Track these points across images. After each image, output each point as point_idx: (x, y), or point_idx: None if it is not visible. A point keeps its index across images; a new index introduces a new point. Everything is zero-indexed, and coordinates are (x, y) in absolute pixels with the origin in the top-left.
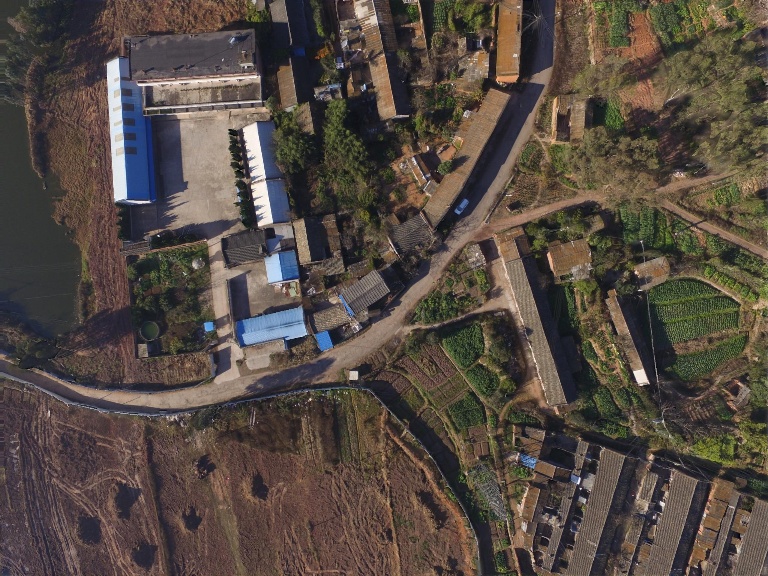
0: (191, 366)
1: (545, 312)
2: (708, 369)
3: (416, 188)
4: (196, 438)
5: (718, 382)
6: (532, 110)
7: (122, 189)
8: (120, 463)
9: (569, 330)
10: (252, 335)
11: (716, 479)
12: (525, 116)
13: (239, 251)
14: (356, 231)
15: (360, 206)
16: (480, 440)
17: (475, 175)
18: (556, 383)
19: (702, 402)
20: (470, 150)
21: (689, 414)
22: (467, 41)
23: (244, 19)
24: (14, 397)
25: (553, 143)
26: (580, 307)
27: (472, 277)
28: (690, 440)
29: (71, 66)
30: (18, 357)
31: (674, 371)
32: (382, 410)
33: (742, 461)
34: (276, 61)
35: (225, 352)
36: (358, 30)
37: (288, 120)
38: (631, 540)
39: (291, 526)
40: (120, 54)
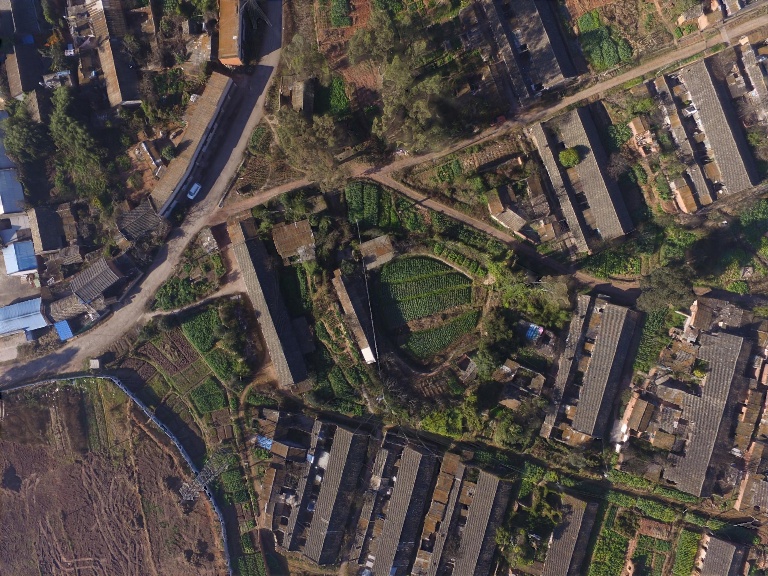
0: None
1: (272, 294)
2: (442, 345)
3: (152, 174)
4: None
5: (451, 357)
6: (262, 92)
7: None
8: None
9: (303, 311)
10: None
11: (442, 453)
12: (255, 99)
13: None
14: (92, 219)
15: (94, 194)
16: (223, 423)
17: (207, 159)
18: (284, 364)
19: (435, 378)
20: (193, 134)
21: (422, 390)
22: (190, 24)
23: None
24: None
25: (279, 125)
26: (310, 288)
27: (209, 262)
28: (417, 415)
29: None
30: None
31: (409, 348)
32: (128, 397)
33: (471, 434)
34: (2, 49)
35: None
36: (85, 16)
37: None
38: (365, 516)
39: (46, 516)
40: None
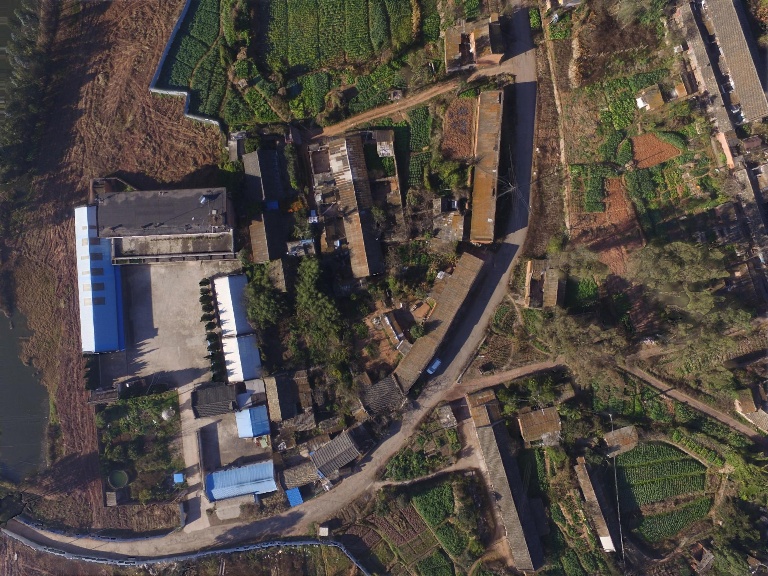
0: (160, 514)
1: (514, 478)
2: (674, 531)
3: (389, 344)
4: None
5: (683, 544)
6: (506, 270)
7: (90, 340)
8: None
9: (538, 492)
10: (222, 490)
11: None
12: (499, 276)
13: (209, 406)
14: (328, 387)
15: (332, 363)
16: None
17: (448, 334)
18: (524, 549)
19: (667, 565)
20: (443, 314)
21: None
22: (442, 202)
23: (217, 164)
24: None
25: (526, 307)
26: (549, 471)
27: (443, 436)
28: None
29: (39, 203)
30: None
31: (640, 532)
32: (352, 564)
33: None
34: (248, 215)
35: (195, 501)
36: (332, 185)
37: (260, 273)
38: None
39: None
40: (89, 197)
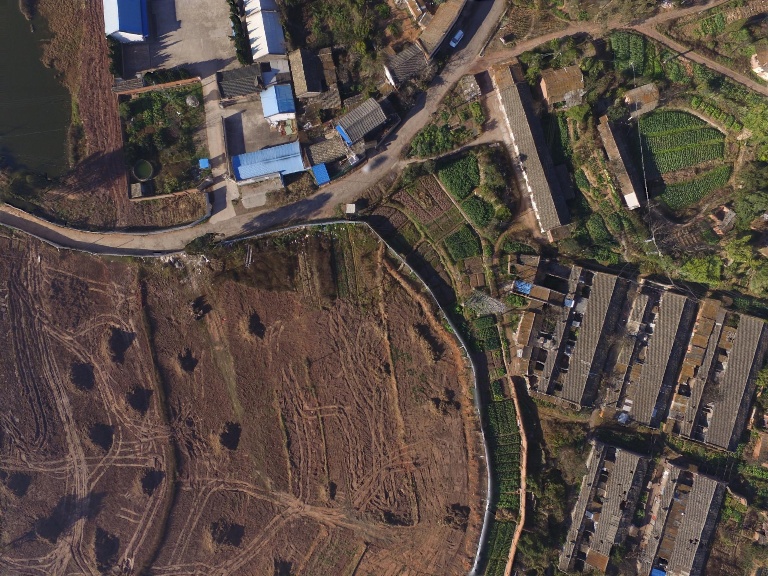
0: (186, 207)
1: (539, 138)
2: (695, 198)
3: (411, 23)
4: (191, 279)
5: (705, 210)
6: None
7: (114, 22)
8: (113, 307)
9: (562, 160)
10: (248, 168)
11: (704, 297)
12: None
13: (234, 83)
14: (352, 65)
15: (356, 39)
16: (476, 271)
17: (469, 9)
18: (550, 207)
19: (690, 228)
20: None
21: (677, 240)
22: None
23: None
24: (2, 244)
25: None
26: (573, 135)
27: (467, 110)
28: (679, 261)
29: None
30: (6, 201)
31: (663, 200)
32: (379, 245)
33: (728, 282)
34: None
35: (220, 192)
36: None
37: None
38: (623, 360)
39: (289, 364)
40: None
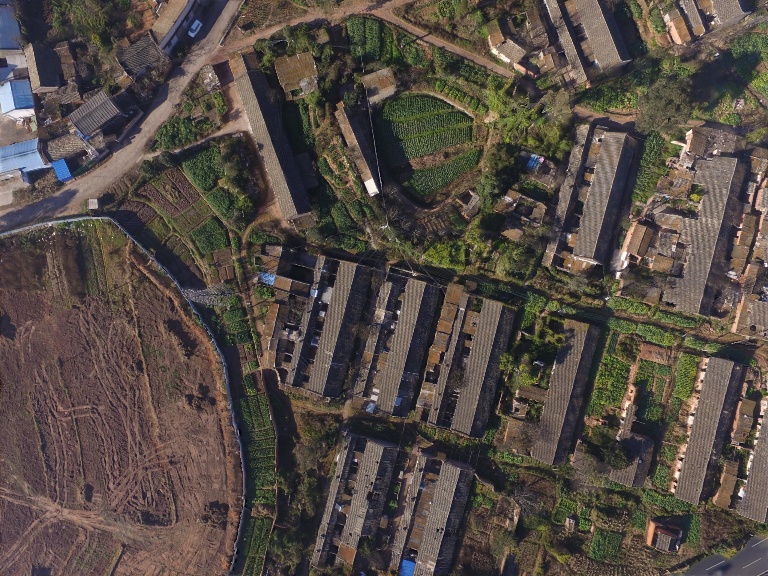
0: None
1: (275, 126)
2: (444, 183)
3: (152, 14)
4: None
5: (453, 194)
6: None
7: None
8: None
9: (306, 148)
10: None
11: (446, 282)
12: None
13: None
14: (90, 58)
15: (93, 32)
16: (225, 264)
17: None
18: (287, 195)
19: (437, 213)
20: None
21: (425, 225)
22: None
23: None
24: None
25: None
26: (313, 123)
27: (210, 100)
28: (420, 246)
29: None
30: None
31: (411, 186)
32: (128, 240)
33: (474, 266)
34: None
35: None
36: None
37: None
38: (369, 349)
39: (41, 365)
40: None
